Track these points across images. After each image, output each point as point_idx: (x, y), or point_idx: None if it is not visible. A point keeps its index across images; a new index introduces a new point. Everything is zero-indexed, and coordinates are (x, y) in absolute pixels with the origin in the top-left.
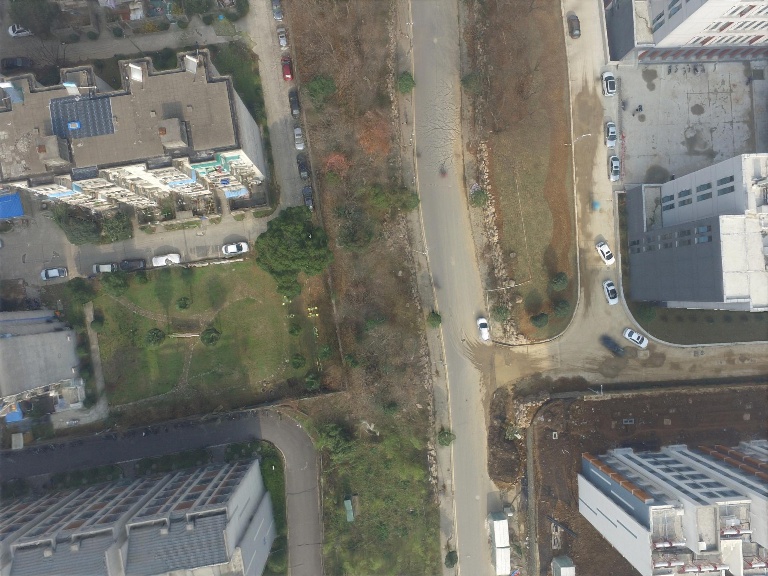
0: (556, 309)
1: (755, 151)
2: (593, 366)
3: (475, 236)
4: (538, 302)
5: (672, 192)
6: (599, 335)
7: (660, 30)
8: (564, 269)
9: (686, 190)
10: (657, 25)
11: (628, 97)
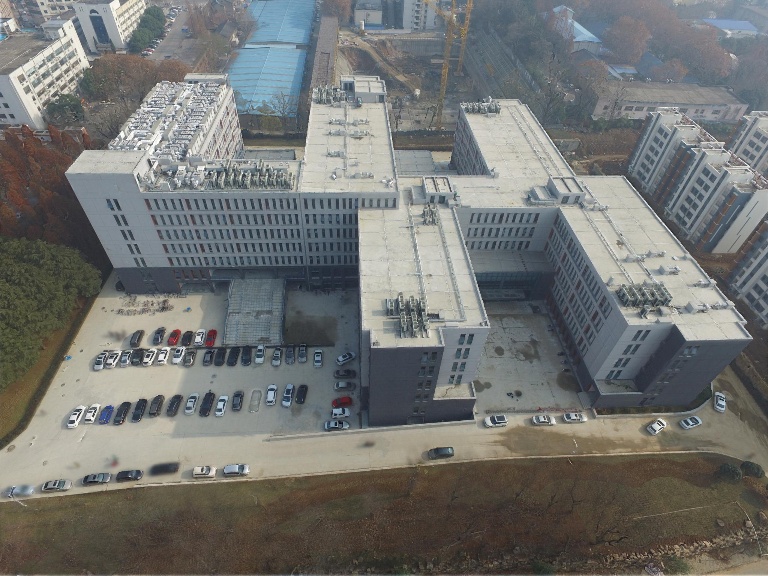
0: (761, 476)
1: (522, 314)
2: (766, 439)
3: (707, 571)
4: (751, 494)
5: (608, 372)
6: (734, 433)
7: (464, 378)
8: (698, 466)
9: (617, 362)
10: (458, 380)
11: (502, 404)
